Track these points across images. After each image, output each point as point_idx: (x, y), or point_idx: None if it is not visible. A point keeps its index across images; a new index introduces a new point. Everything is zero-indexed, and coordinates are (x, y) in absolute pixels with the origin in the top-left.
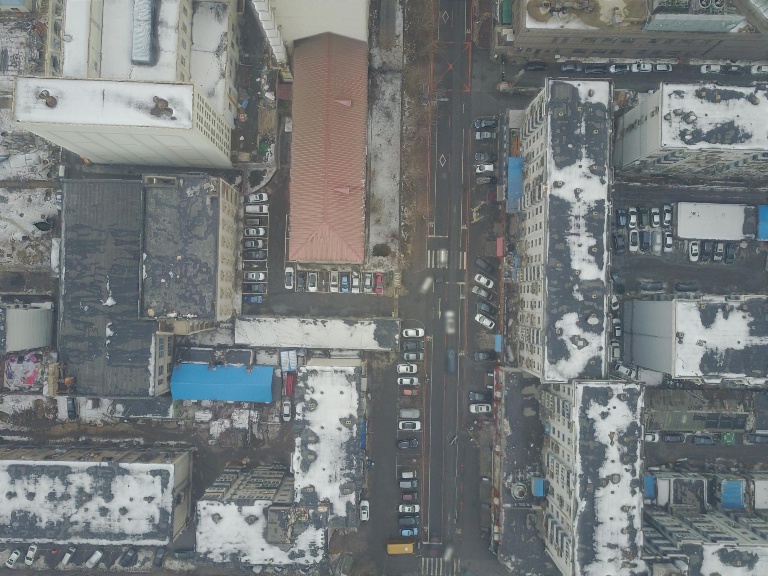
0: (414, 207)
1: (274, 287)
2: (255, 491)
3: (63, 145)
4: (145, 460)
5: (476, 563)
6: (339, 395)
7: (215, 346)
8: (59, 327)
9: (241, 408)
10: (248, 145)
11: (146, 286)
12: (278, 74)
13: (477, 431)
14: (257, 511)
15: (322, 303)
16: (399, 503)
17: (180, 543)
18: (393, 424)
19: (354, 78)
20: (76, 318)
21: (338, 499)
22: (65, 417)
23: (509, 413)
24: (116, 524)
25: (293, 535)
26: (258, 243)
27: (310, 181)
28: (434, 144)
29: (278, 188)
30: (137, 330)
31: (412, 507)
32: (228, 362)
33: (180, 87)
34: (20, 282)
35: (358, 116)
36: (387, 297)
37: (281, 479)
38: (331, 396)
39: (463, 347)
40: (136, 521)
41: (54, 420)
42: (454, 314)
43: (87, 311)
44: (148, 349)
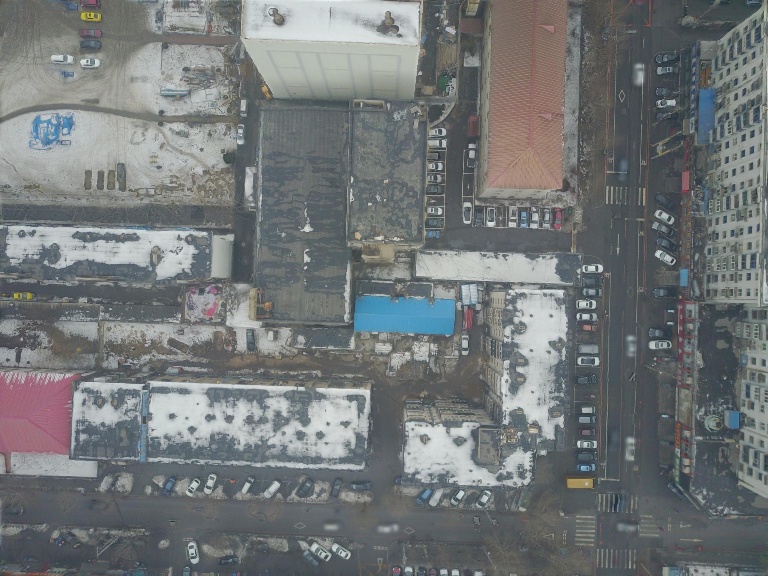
0: (593, 143)
1: (451, 222)
2: (456, 416)
3: (263, 72)
4: (337, 387)
5: (654, 500)
6: (548, 318)
7: (393, 280)
8: (256, 253)
9: (421, 341)
10: (426, 80)
11: (353, 209)
12: (461, 7)
13: (656, 368)
14: (465, 433)
15: (499, 238)
16: (577, 439)
17: (357, 475)
18: (571, 360)
19: (556, 4)
20: (273, 244)
21: (547, 422)
22: (244, 349)
23: (702, 345)
24: (313, 448)
25: (502, 457)
26: (437, 178)
27: (513, 107)
28: (613, 79)
29: (456, 123)
30: (333, 257)
31: (591, 443)
32: (409, 295)
33: (406, 4)
34: (200, 216)
35: (559, 43)
36: (565, 233)
37: (469, 409)
38: (540, 319)
39: (642, 284)
40: (333, 445)
41: (233, 352)
42: (633, 250)
43: (284, 237)
44: (344, 276)
